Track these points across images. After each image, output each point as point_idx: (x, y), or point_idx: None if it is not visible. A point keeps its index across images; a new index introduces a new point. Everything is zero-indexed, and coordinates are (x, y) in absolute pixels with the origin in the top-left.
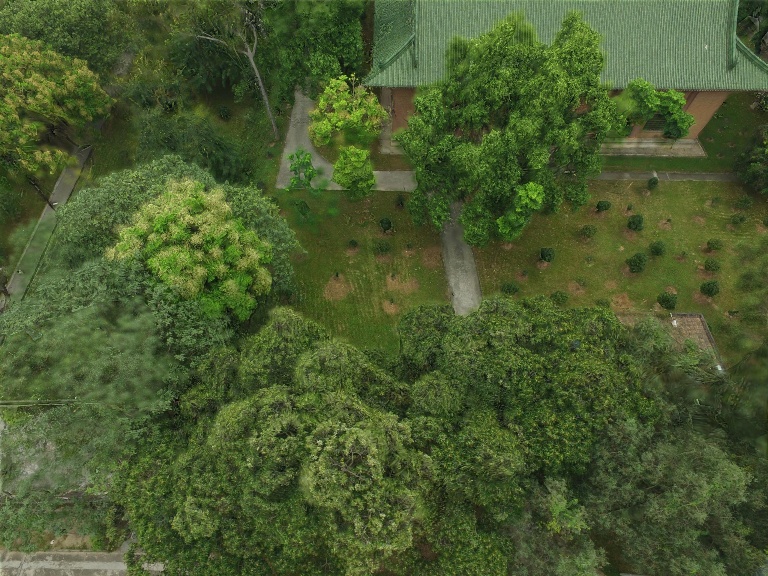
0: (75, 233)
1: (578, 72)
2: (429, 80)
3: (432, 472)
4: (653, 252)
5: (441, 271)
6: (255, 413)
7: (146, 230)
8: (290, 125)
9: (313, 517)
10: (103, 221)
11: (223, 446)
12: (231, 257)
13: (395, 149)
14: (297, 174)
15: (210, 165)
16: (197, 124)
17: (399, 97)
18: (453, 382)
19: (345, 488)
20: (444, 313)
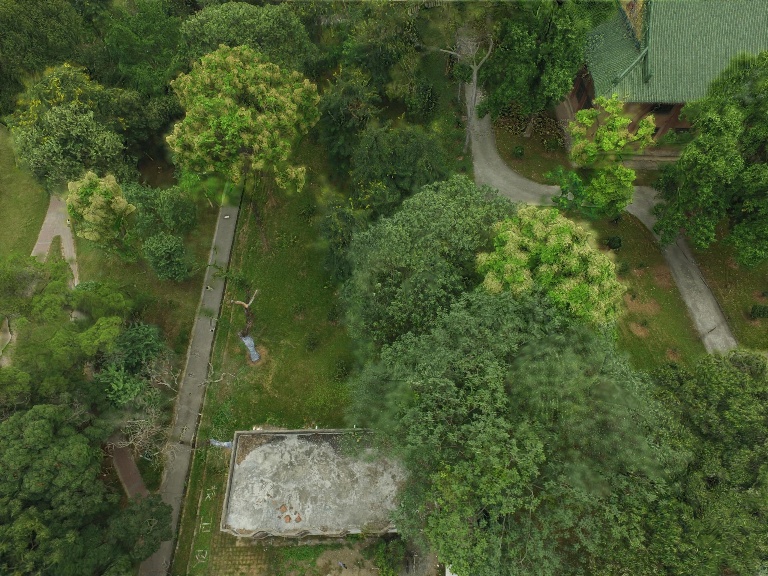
0: (426, 261)
1: None
2: (660, 95)
3: None
4: None
5: (675, 291)
6: None
7: (528, 260)
8: (471, 138)
9: None
10: (453, 248)
11: None
12: None
13: None
14: None
15: (430, 181)
16: (417, 139)
17: None
18: None
19: None
20: None
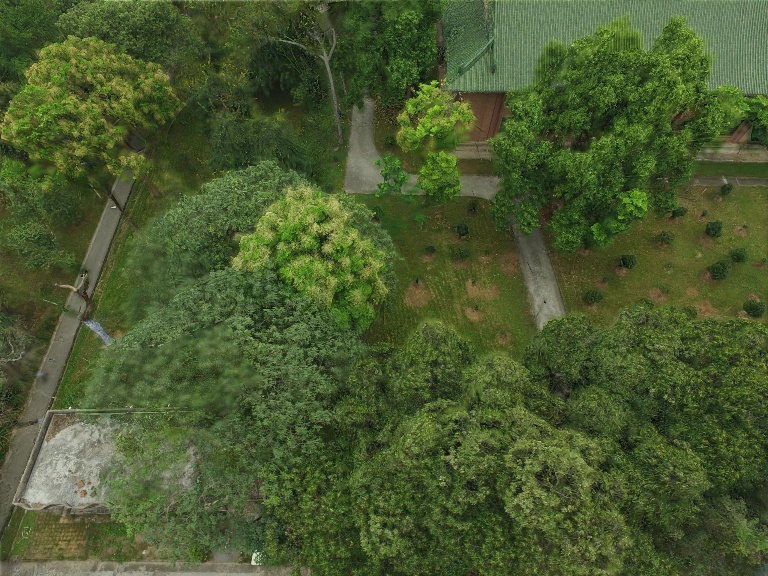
0: (191, 241)
1: (691, 79)
2: (507, 85)
3: (621, 491)
4: (734, 259)
5: (520, 277)
6: (440, 430)
7: (272, 239)
8: (352, 129)
9: (509, 538)
10: (219, 229)
11: (407, 464)
12: (356, 266)
13: (460, 153)
14: (387, 180)
15: (284, 170)
16: (271, 128)
17: (471, 101)
18: (614, 396)
19: (556, 509)
20: (581, 324)
